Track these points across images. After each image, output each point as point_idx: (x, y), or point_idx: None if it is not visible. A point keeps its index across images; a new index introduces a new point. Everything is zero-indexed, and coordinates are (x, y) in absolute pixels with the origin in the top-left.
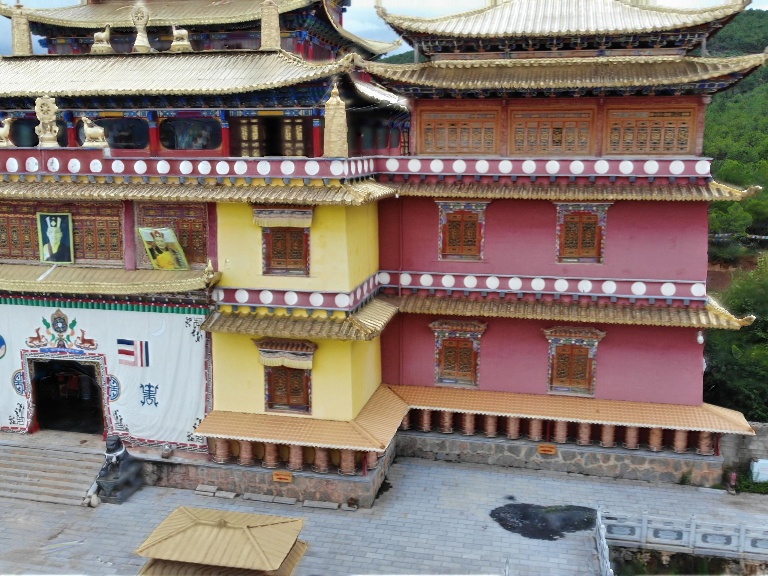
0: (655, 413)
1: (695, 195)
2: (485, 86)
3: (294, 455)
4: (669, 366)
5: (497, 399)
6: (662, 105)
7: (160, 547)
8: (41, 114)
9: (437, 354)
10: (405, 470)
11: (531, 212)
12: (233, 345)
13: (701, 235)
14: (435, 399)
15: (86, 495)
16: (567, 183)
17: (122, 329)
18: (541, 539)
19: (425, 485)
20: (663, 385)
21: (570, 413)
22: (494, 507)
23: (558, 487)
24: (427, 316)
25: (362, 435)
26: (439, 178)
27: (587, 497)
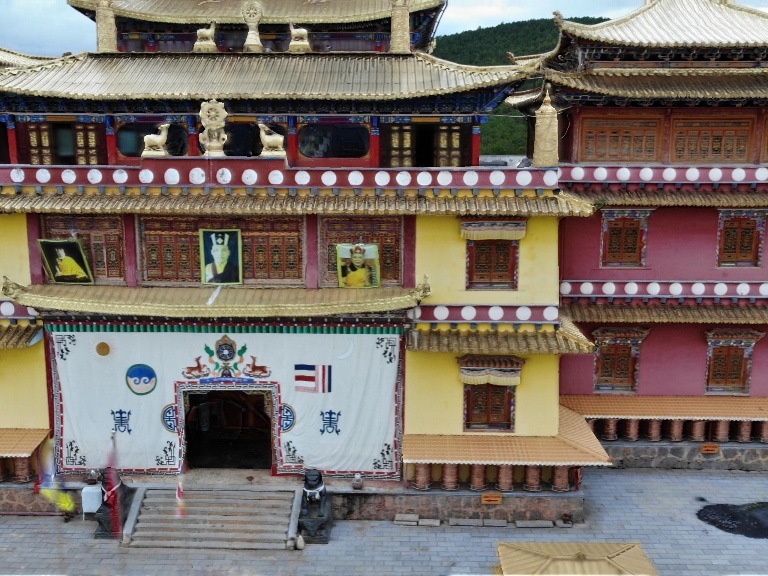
0: None
1: None
2: (661, 95)
3: (504, 475)
4: None
5: (661, 403)
6: None
7: None
8: (208, 120)
9: (595, 362)
10: None
11: (694, 218)
12: (431, 365)
13: None
14: (602, 407)
15: (287, 537)
16: (730, 190)
17: (301, 353)
18: (766, 538)
19: (613, 494)
20: None
21: (738, 412)
22: (696, 510)
23: (734, 485)
24: (592, 324)
25: (579, 449)
26: (603, 186)
27: (767, 492)
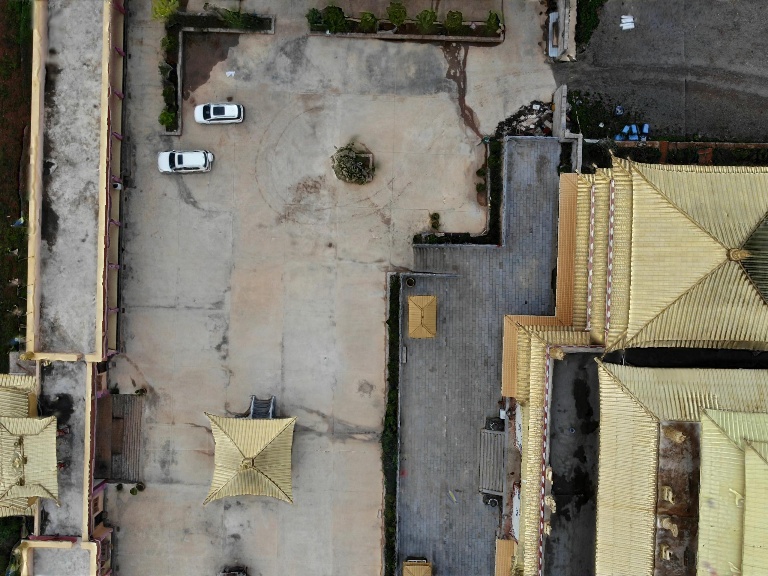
0: None
1: None
2: None
3: None
4: None
5: None
6: None
7: (407, 573)
8: None
9: None
10: None
11: None
12: None
13: None
14: None
15: (483, 489)
16: None
17: None
18: None
19: None
20: None
21: None
22: None
23: None
24: None
25: None
26: None
27: None
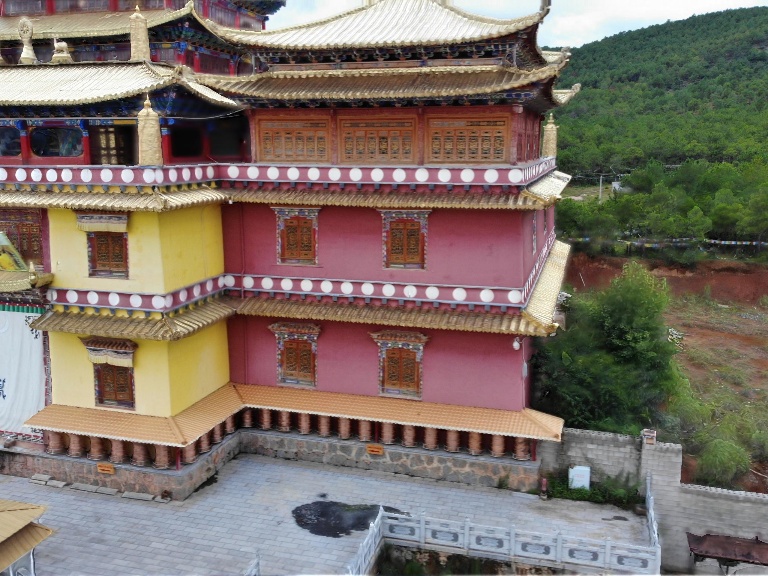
0: (473, 417)
1: (500, 203)
2: (307, 96)
3: (115, 448)
4: (490, 371)
5: (329, 400)
6: (478, 114)
7: None
8: None
9: (279, 355)
10: (239, 466)
11: (358, 218)
12: (66, 343)
13: (516, 243)
14: (272, 398)
15: None
16: (390, 190)
17: None
18: (326, 536)
19: (249, 481)
20: (485, 390)
21: (391, 415)
22: (301, 504)
23: (376, 487)
24: (265, 318)
25: (172, 431)
26: (275, 185)
27: (398, 497)
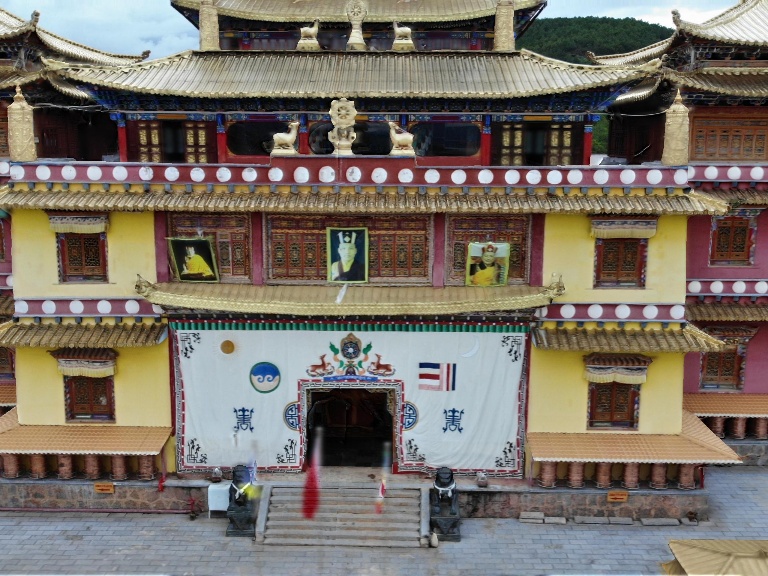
0: None
1: None
2: None
3: (631, 473)
4: None
5: None
6: None
7: None
8: (338, 118)
9: (701, 360)
10: None
11: None
12: (556, 363)
13: None
14: (710, 405)
15: (421, 535)
16: None
17: (427, 352)
18: None
19: (728, 492)
20: None
21: None
22: None
23: None
24: (701, 323)
25: (706, 448)
26: (714, 185)
27: None
